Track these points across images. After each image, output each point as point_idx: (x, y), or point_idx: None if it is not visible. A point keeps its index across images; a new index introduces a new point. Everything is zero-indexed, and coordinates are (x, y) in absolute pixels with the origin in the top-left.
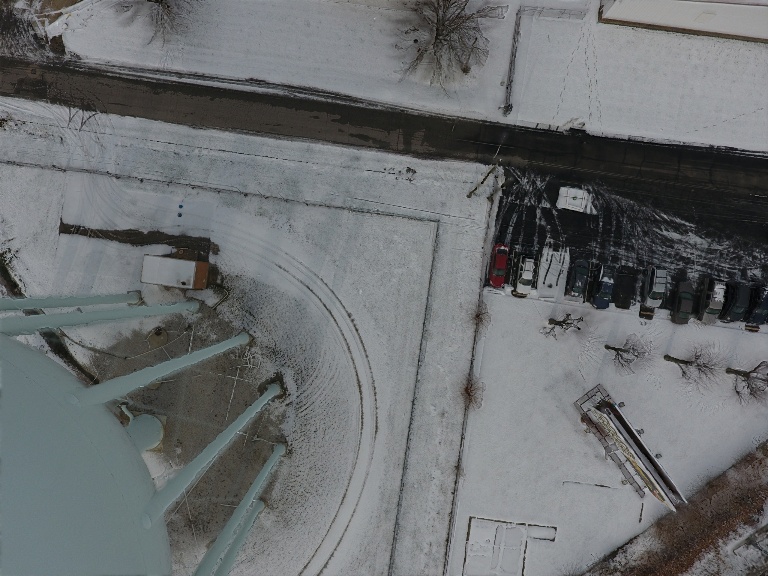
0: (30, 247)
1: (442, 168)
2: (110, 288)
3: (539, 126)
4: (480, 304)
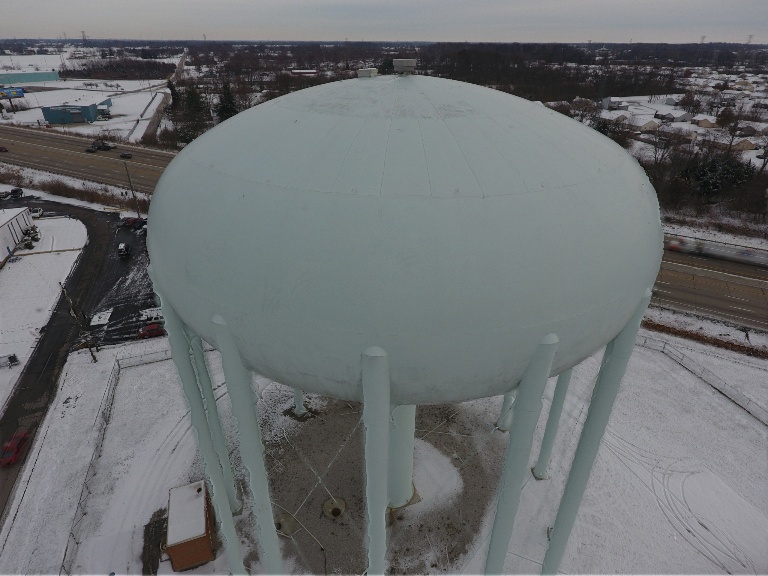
0: None
1: (66, 383)
2: None
3: (33, 346)
4: None
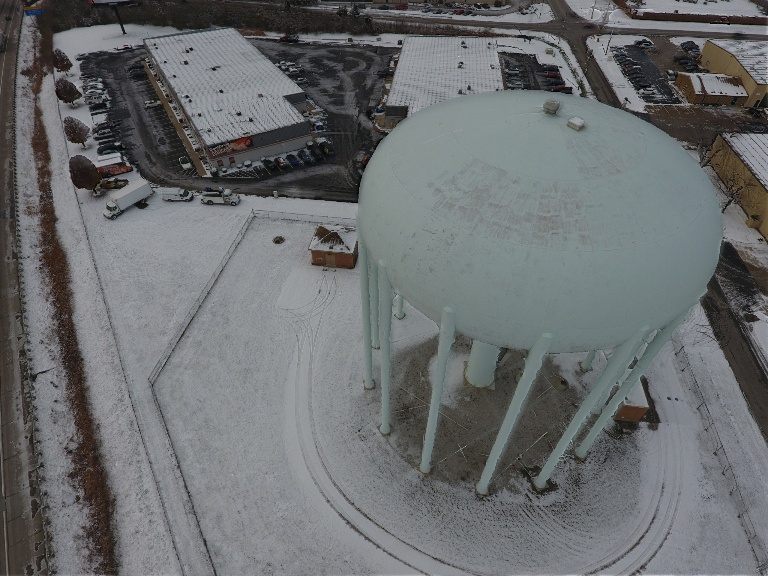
0: None
1: None
2: None
3: None
4: None
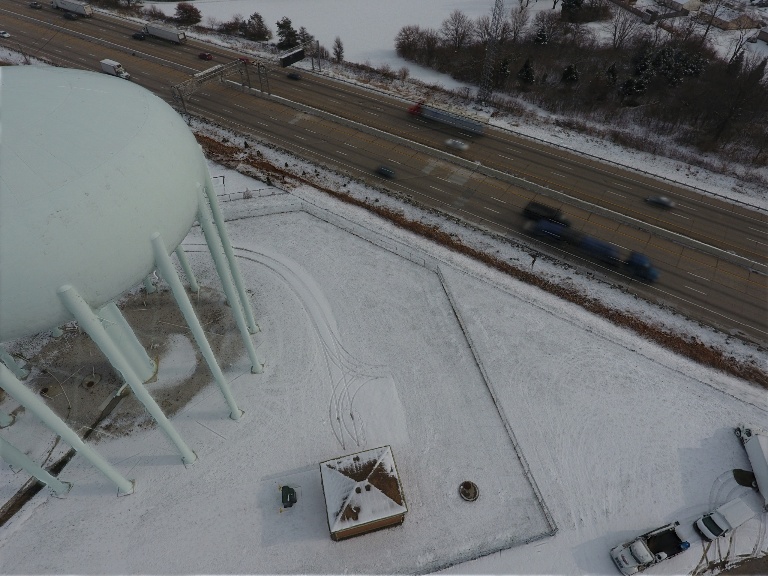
0: None
1: None
2: None
3: None
4: None
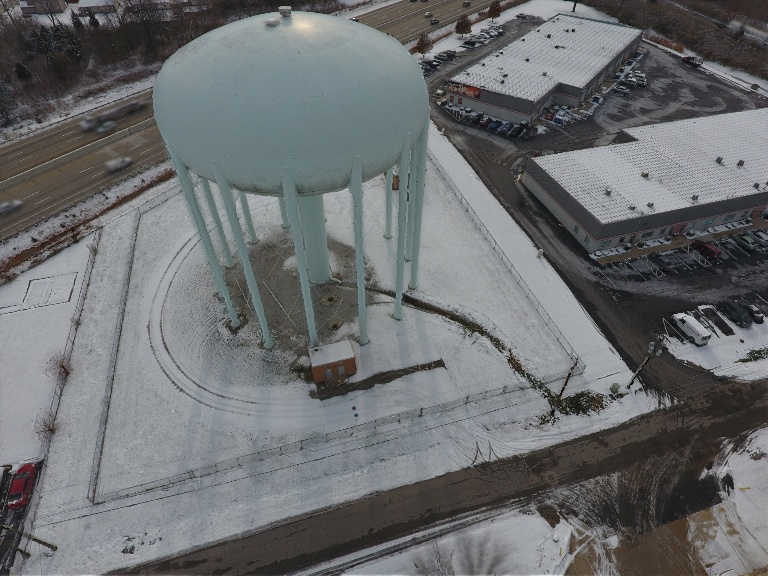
0: (457, 343)
1: (88, 570)
2: (384, 340)
3: None
4: (47, 440)
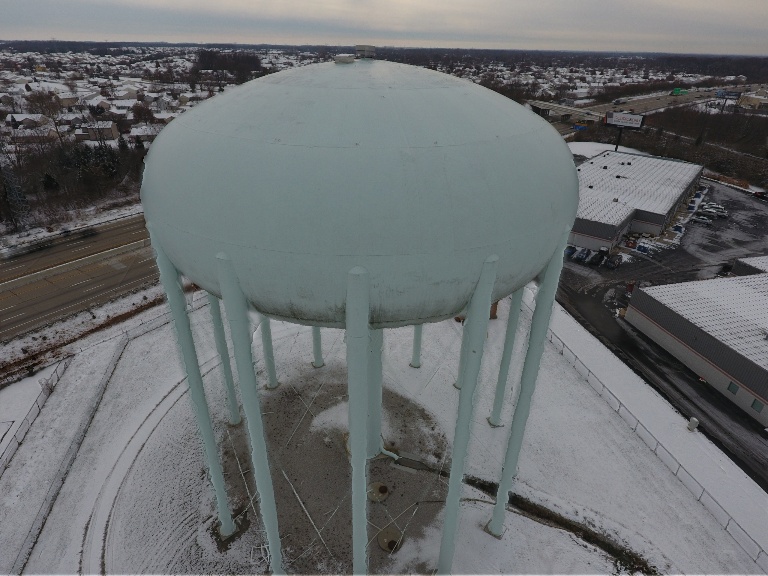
0: None
1: None
2: None
3: None
4: None
